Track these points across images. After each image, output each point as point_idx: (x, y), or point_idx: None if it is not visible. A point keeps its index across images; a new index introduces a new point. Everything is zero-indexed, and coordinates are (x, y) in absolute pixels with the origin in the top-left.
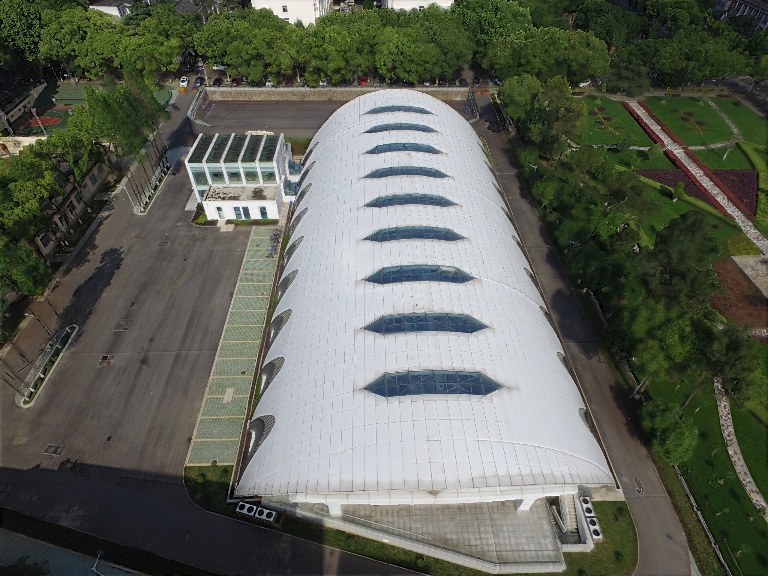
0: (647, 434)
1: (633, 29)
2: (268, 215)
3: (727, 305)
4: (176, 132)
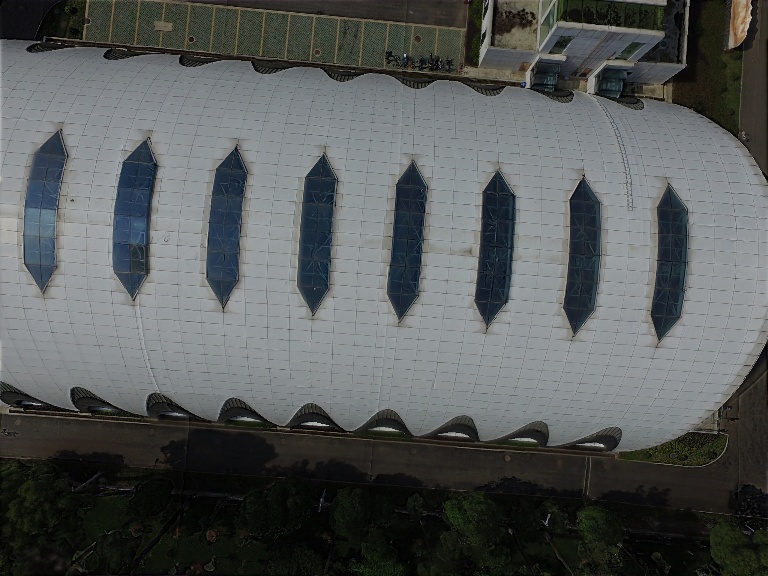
0: None
1: None
2: (482, 47)
3: None
4: None
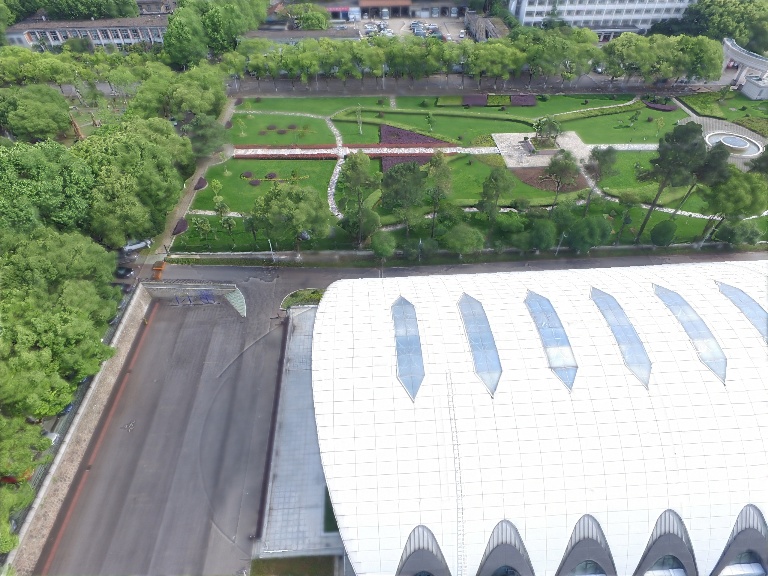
0: (728, 249)
1: None
2: None
3: (570, 184)
4: None
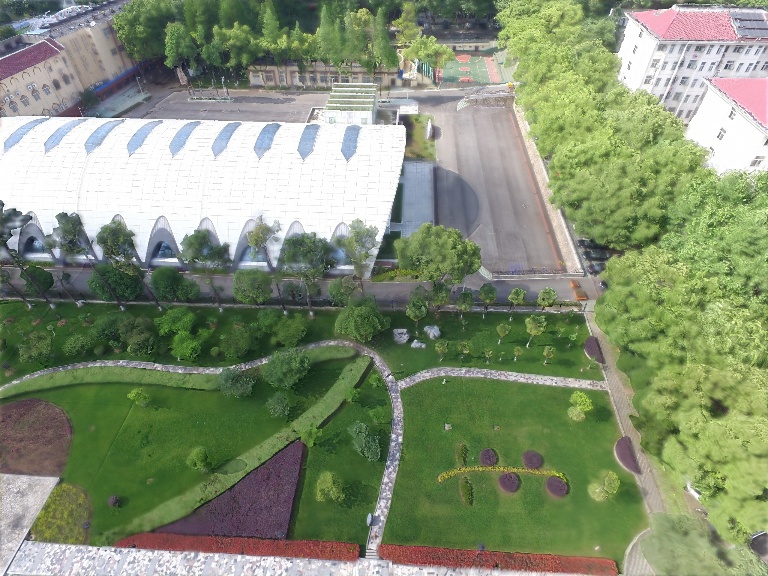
0: None
1: None
2: None
3: (7, 415)
4: (440, 97)
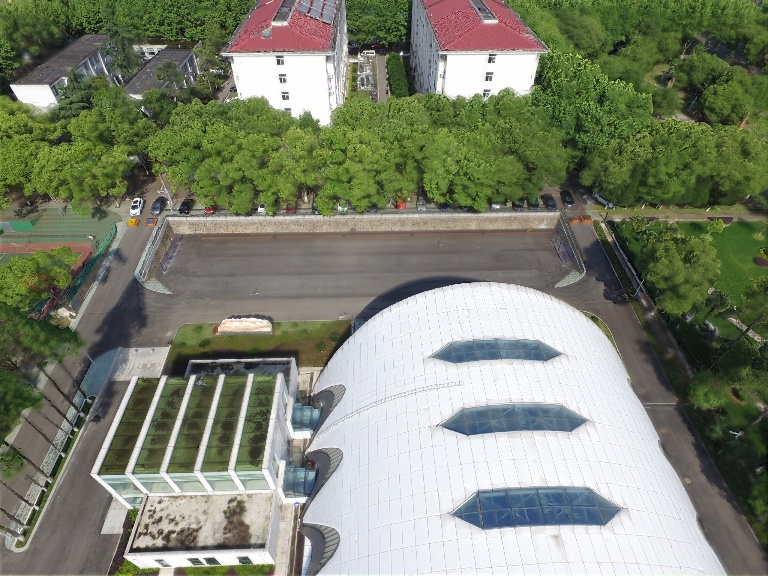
0: None
1: (767, 102)
2: (253, 561)
3: None
4: (113, 313)
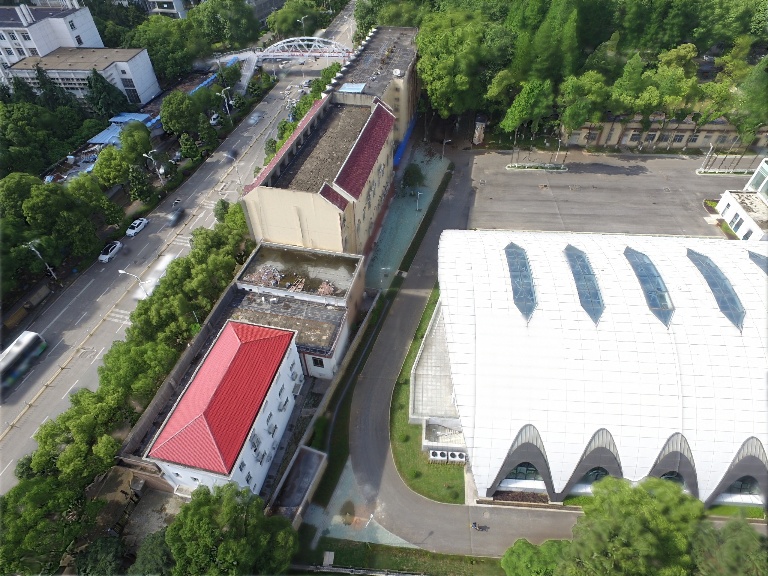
0: None
1: None
2: None
3: None
4: None
